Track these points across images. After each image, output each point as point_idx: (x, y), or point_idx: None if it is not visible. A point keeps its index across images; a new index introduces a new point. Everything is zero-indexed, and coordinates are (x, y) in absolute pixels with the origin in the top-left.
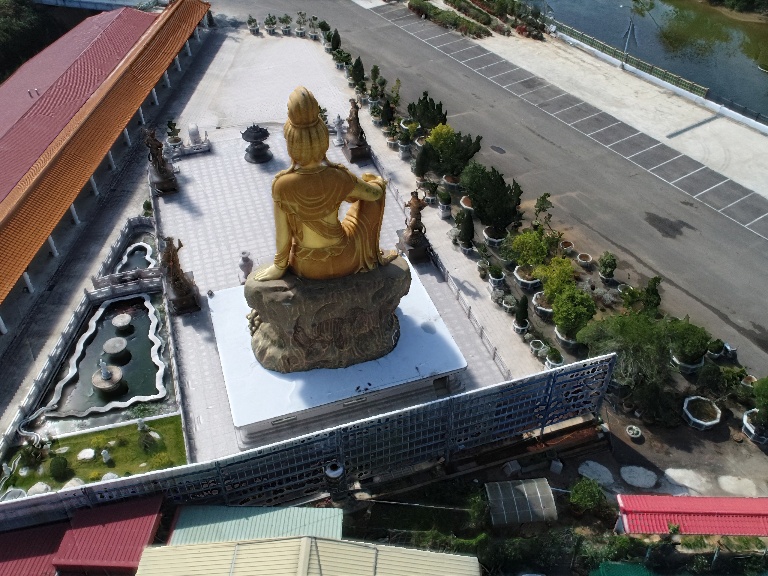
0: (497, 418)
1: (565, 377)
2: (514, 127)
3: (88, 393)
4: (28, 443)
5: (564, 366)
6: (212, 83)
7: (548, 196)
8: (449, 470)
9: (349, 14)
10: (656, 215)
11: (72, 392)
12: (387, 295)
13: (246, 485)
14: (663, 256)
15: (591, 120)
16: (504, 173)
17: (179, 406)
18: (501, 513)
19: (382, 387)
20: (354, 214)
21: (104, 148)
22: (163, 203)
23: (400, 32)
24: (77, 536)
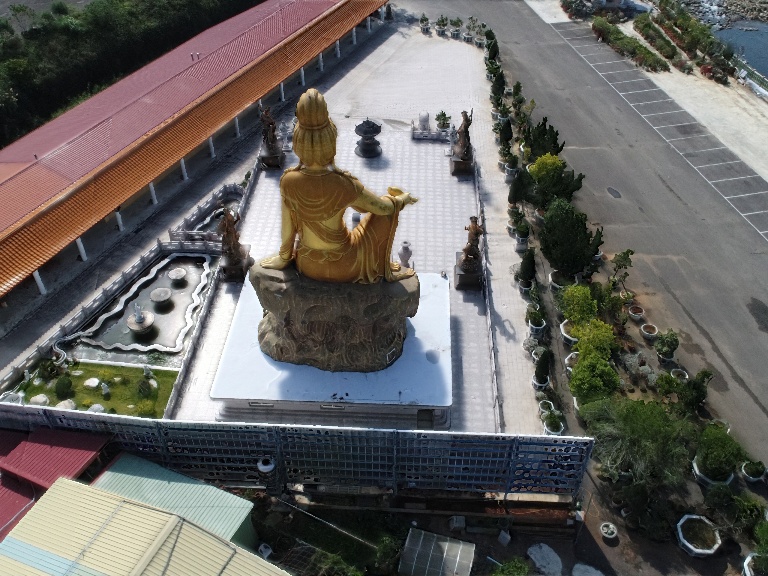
0: (451, 467)
1: (531, 447)
2: (644, 172)
3: (125, 330)
4: (56, 358)
5: (529, 435)
6: (362, 73)
7: (631, 253)
8: (395, 503)
9: (526, 26)
10: (763, 303)
11: (112, 325)
12: (382, 312)
13: (188, 452)
14: (747, 351)
15: (738, 182)
16: (608, 219)
17: (182, 364)
18: (411, 563)
19: (357, 401)
20: (364, 224)
21: (229, 116)
22: (264, 177)
23: (570, 52)
24: (27, 448)
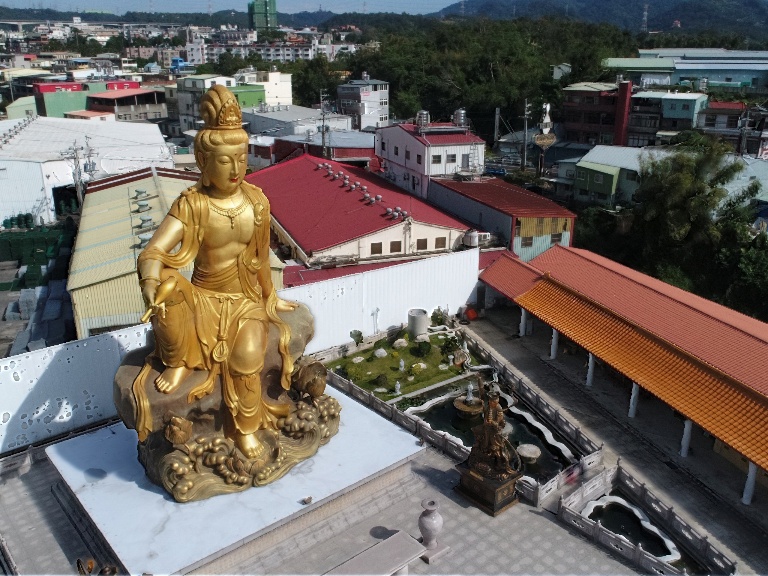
0: (23, 408)
1: None
2: None
3: None
4: None
5: None
6: None
7: None
8: None
9: None
10: None
11: None
12: None
13: None
14: None
15: None
16: None
17: None
18: None
19: None
20: None
21: None
22: None
23: None
24: None
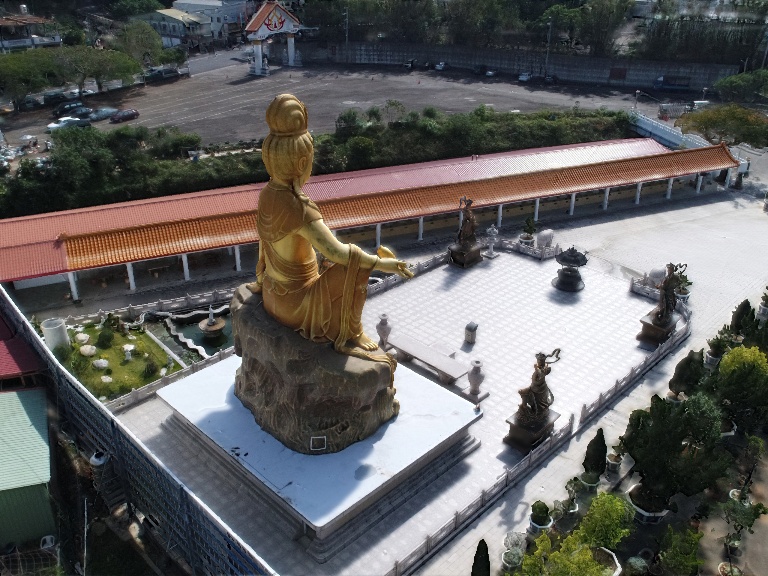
0: None
1: None
2: None
3: None
4: None
5: None
6: (646, 223)
7: (763, 511)
8: None
9: None
10: None
11: None
12: (305, 376)
13: None
14: None
15: None
16: None
17: None
18: None
19: (247, 465)
20: None
21: (449, 207)
22: (442, 268)
23: None
24: None
